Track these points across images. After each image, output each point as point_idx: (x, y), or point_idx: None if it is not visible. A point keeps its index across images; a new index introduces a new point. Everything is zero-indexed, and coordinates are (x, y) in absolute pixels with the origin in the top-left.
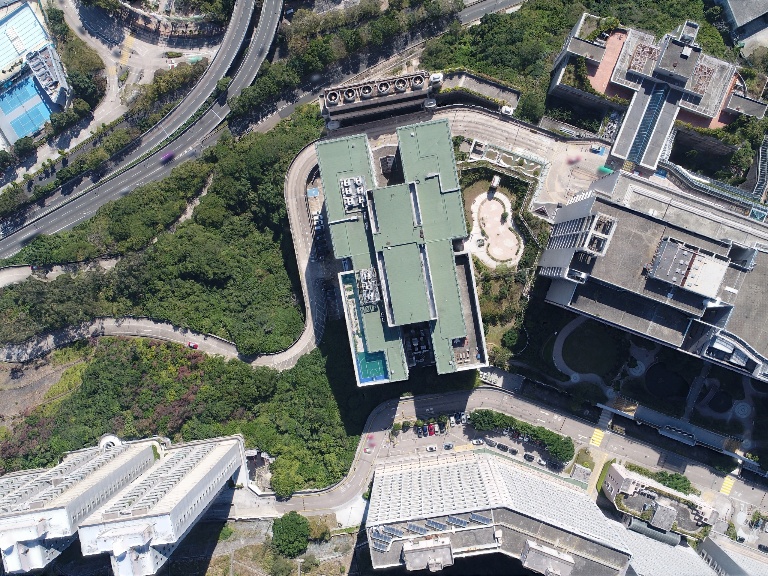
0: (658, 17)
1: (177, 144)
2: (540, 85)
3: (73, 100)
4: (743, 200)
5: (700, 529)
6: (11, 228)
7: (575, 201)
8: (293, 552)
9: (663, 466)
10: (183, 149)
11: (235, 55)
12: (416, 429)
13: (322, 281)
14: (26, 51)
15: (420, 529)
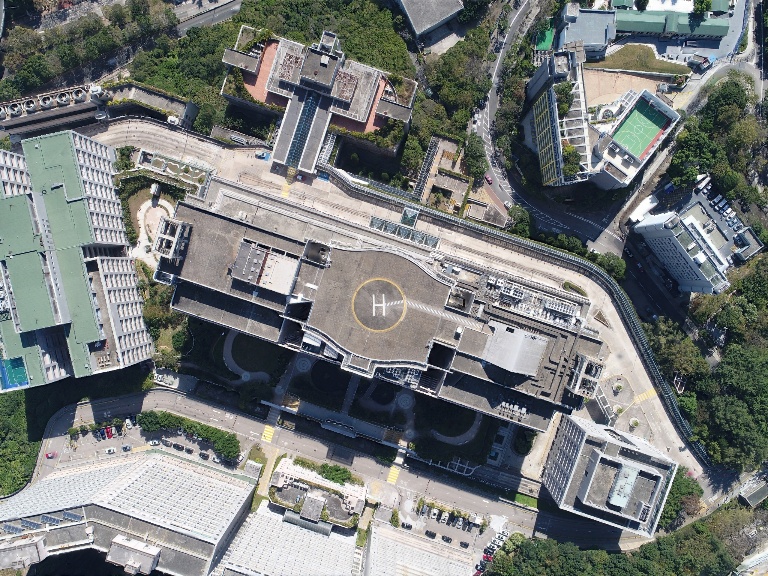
0: (350, 27)
1: None
2: None
3: None
4: (398, 200)
5: (351, 518)
6: None
7: None
8: None
9: (332, 459)
10: None
11: None
12: (95, 433)
13: None
14: None
15: (15, 529)
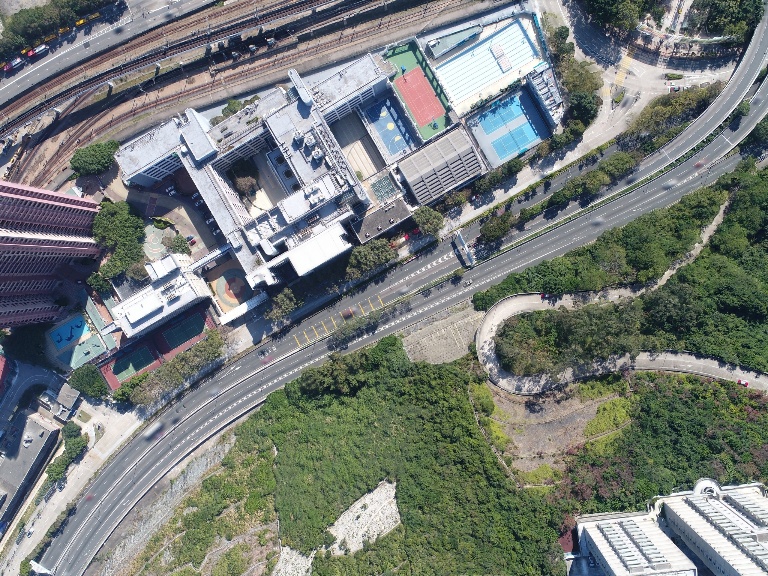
0: None
1: (681, 169)
2: None
3: (568, 121)
4: None
5: None
6: (485, 252)
7: None
8: None
9: None
10: (688, 175)
11: (755, 79)
12: None
13: None
14: (511, 69)
15: None
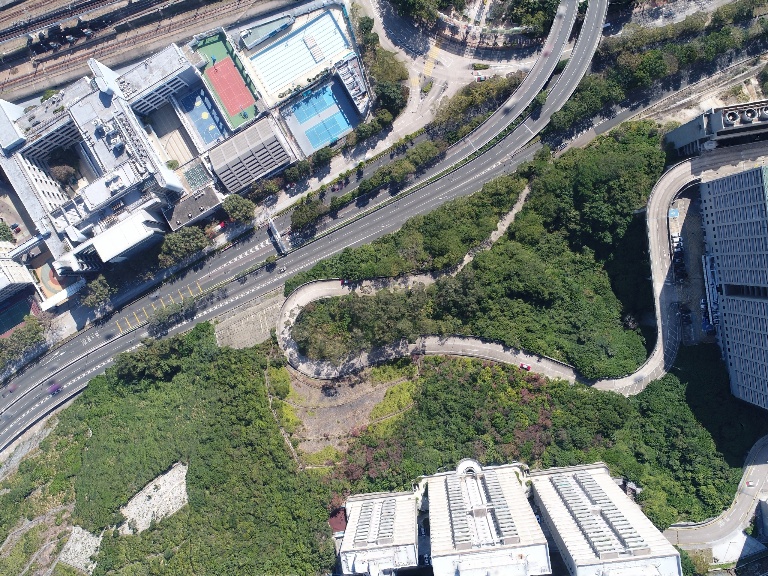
0: None
1: (485, 158)
2: None
3: (376, 111)
4: None
5: None
6: (300, 239)
7: None
8: None
9: None
10: (491, 163)
11: (553, 69)
12: None
13: (679, 305)
14: (324, 59)
15: None
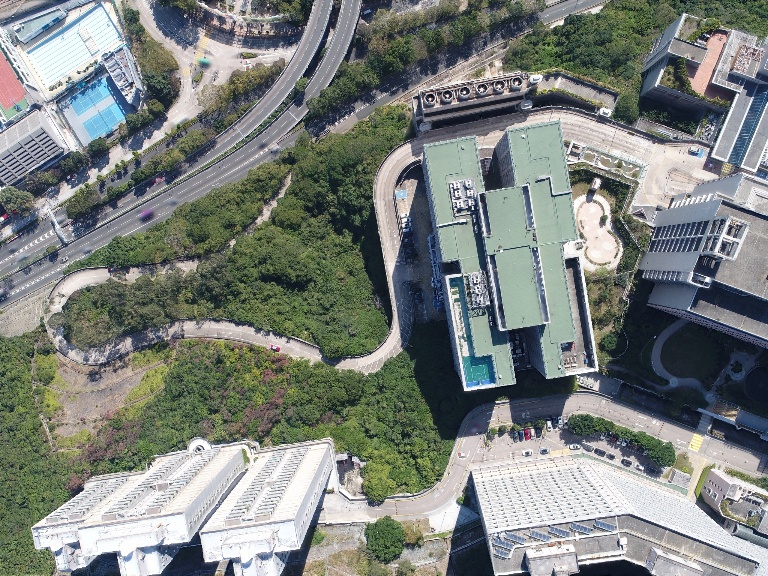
0: (747, 18)
1: (253, 145)
2: (632, 86)
3: (147, 101)
4: None
5: None
6: (83, 229)
7: (685, 204)
8: (389, 557)
9: (763, 471)
10: (259, 150)
11: (313, 56)
12: (512, 433)
13: (410, 284)
14: (99, 52)
15: (543, 536)
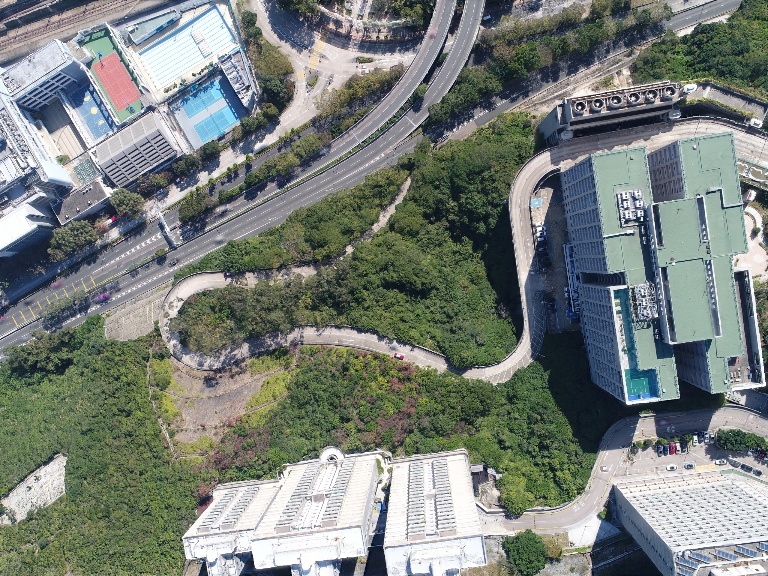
0: None
1: (369, 150)
2: None
3: (262, 104)
4: None
5: None
6: (191, 233)
7: None
8: (532, 572)
9: None
10: (375, 156)
11: (433, 61)
12: (656, 448)
13: (543, 293)
14: (212, 54)
15: (730, 555)
